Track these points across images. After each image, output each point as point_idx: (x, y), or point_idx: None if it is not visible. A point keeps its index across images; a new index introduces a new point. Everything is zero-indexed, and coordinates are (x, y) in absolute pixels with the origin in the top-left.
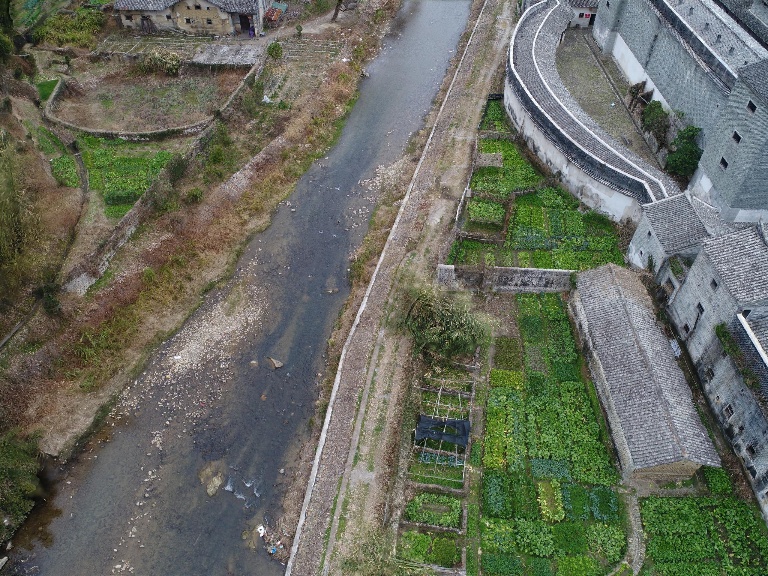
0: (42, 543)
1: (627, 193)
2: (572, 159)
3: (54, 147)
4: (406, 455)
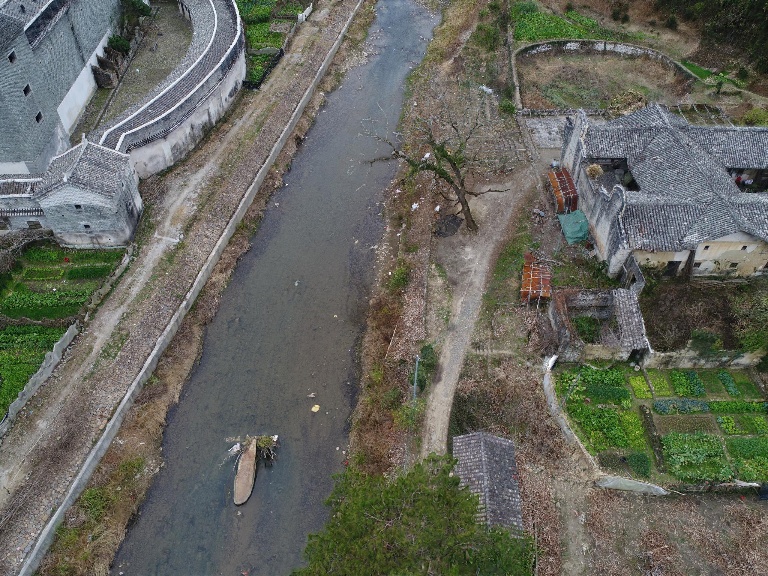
0: None
1: None
2: None
3: None
4: None
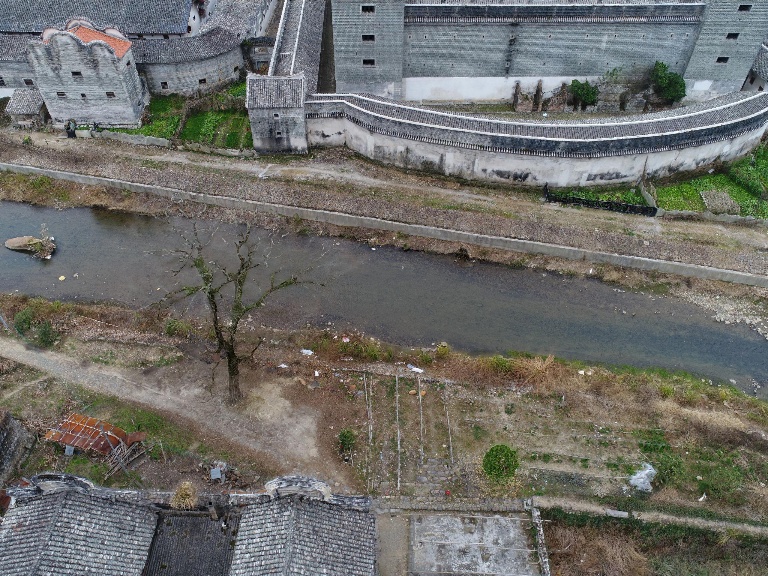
0: None
1: None
2: (740, 133)
3: None
4: None
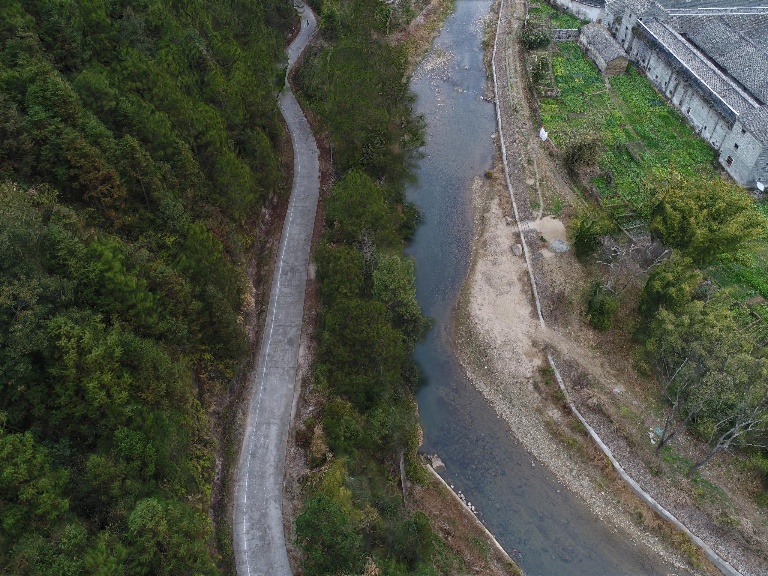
0: None
1: (598, 6)
2: None
3: None
4: None
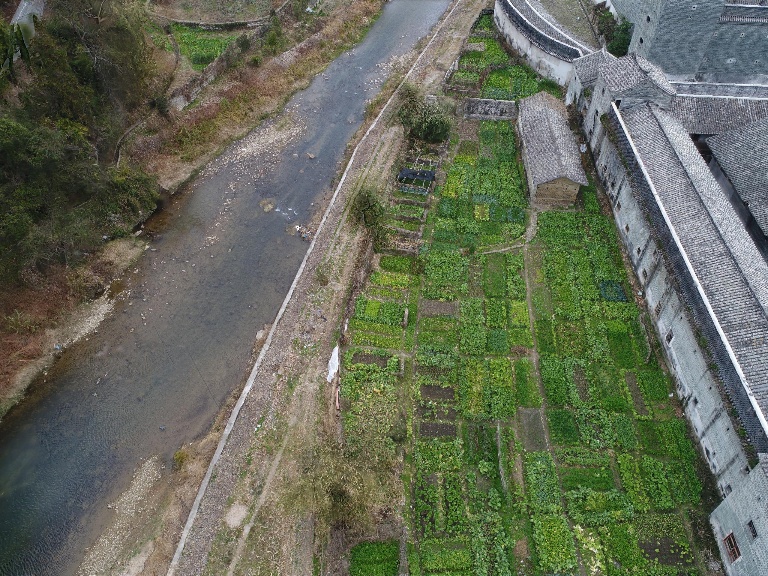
0: (162, 226)
1: (568, 60)
2: (533, 41)
3: (153, 30)
4: (392, 183)
